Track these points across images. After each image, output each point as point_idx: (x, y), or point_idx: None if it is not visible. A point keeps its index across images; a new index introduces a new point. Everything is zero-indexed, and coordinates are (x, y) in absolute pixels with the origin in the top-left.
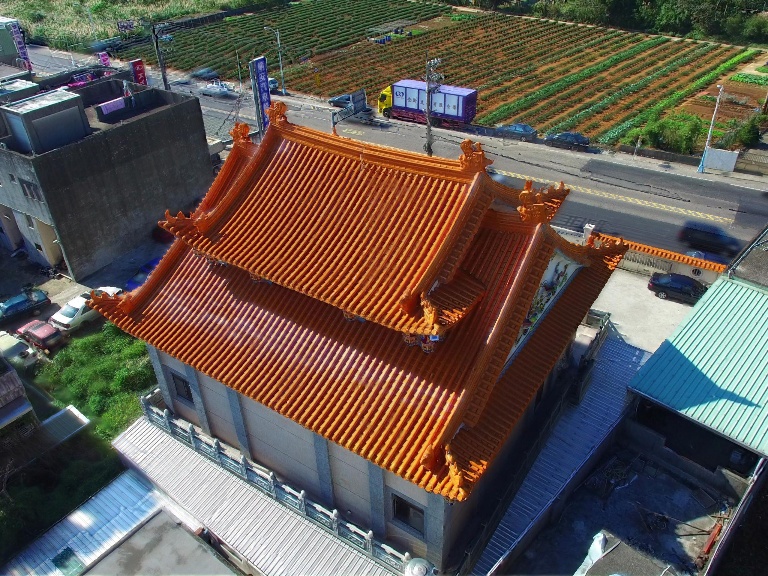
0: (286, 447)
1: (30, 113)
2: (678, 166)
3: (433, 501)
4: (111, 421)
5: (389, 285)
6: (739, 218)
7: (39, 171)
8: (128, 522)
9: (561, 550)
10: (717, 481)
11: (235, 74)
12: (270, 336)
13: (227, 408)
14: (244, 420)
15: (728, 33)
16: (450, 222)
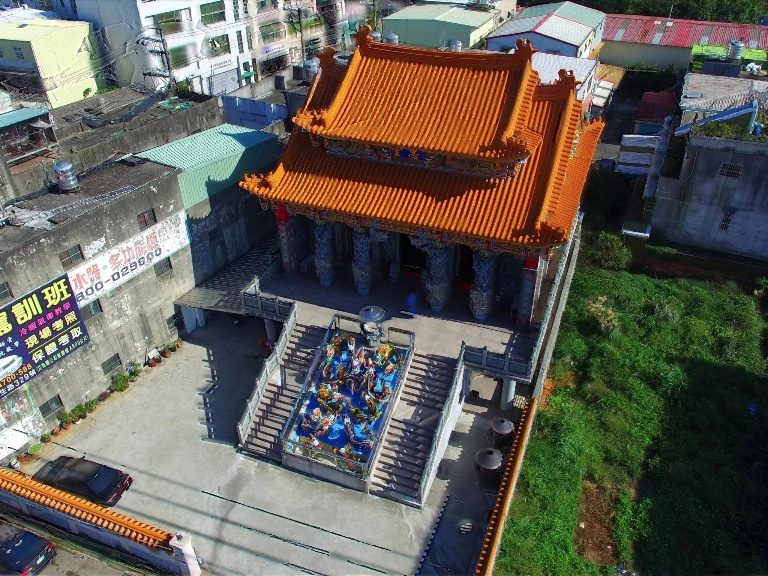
0: None
1: None
2: None
3: None
4: None
5: None
6: None
7: None
8: None
9: None
10: None
11: None
12: None
13: None
14: None
15: None
16: None
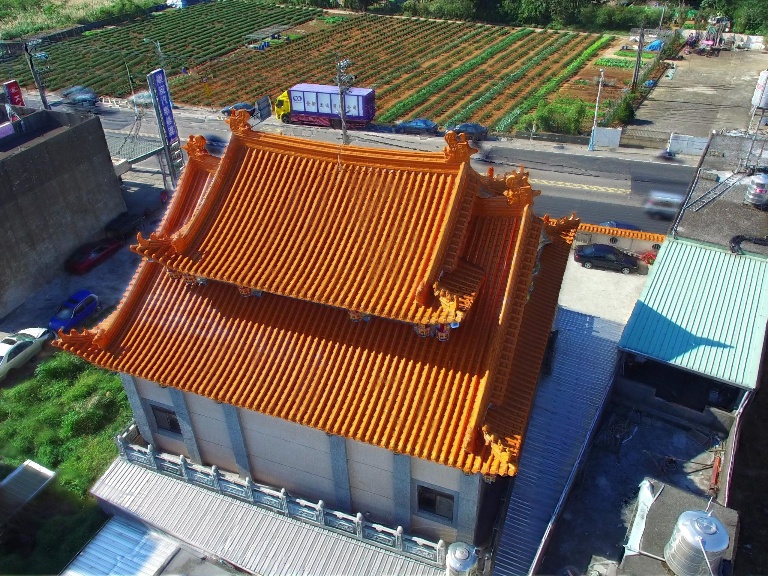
0: (294, 460)
1: None
2: (571, 146)
3: (466, 484)
4: (79, 469)
5: (396, 281)
6: (634, 188)
7: None
8: (130, 571)
9: (593, 506)
10: (706, 419)
11: (127, 89)
12: (272, 349)
13: (222, 432)
14: (244, 441)
15: (583, 22)
16: (443, 213)
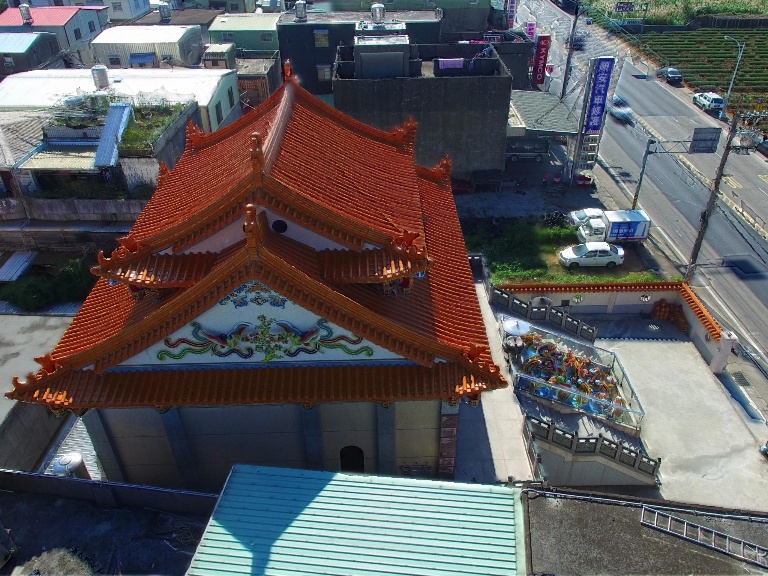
0: None
1: (361, 46)
2: None
3: None
4: None
5: None
6: None
7: (336, 92)
8: None
9: (70, 522)
10: None
11: None
12: None
13: None
14: None
15: None
16: None
